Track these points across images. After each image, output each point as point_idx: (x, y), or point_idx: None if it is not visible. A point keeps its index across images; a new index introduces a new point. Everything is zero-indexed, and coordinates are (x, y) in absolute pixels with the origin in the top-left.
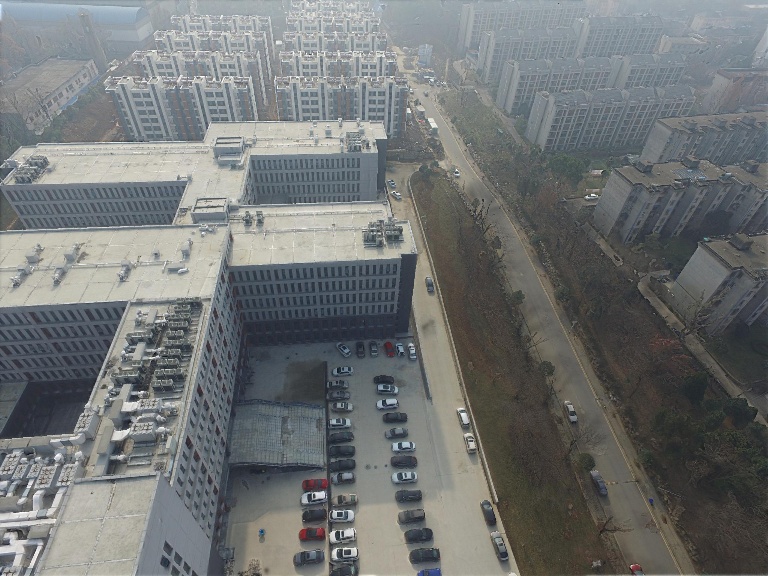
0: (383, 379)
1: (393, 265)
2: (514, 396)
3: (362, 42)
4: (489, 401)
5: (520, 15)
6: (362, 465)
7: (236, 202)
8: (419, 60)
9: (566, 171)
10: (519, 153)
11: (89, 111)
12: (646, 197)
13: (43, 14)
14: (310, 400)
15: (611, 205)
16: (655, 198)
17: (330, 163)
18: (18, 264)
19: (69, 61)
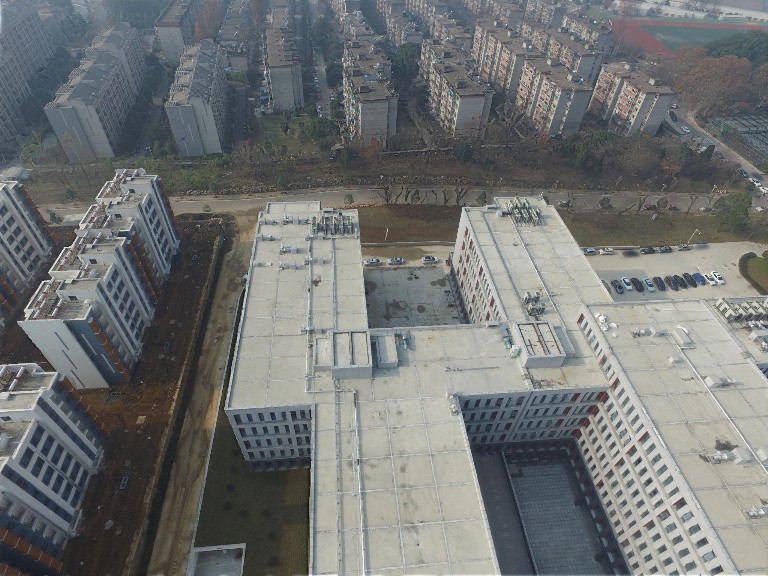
0: None
1: None
2: (572, 220)
3: None
4: (576, 234)
5: None
6: None
7: (508, 323)
8: None
9: None
10: None
11: None
12: None
13: None
14: None
15: (376, 127)
16: None
17: None
18: None
19: None
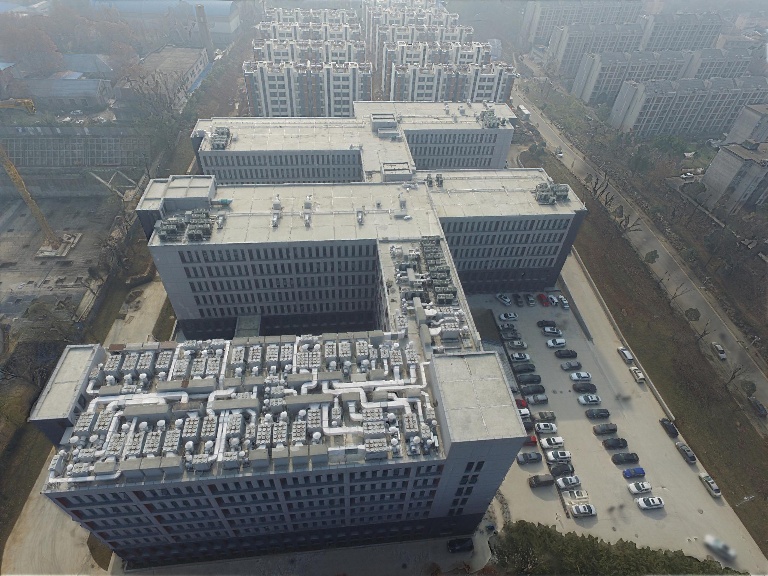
0: (547, 323)
1: (565, 220)
2: (670, 336)
3: (450, 34)
4: (647, 341)
5: (582, 12)
6: (549, 390)
7: (413, 167)
8: None
9: (668, 151)
10: (621, 135)
11: (211, 95)
12: (757, 171)
13: (143, 6)
14: None
15: (717, 180)
16: (765, 172)
17: (470, 138)
18: (266, 210)
19: (185, 49)
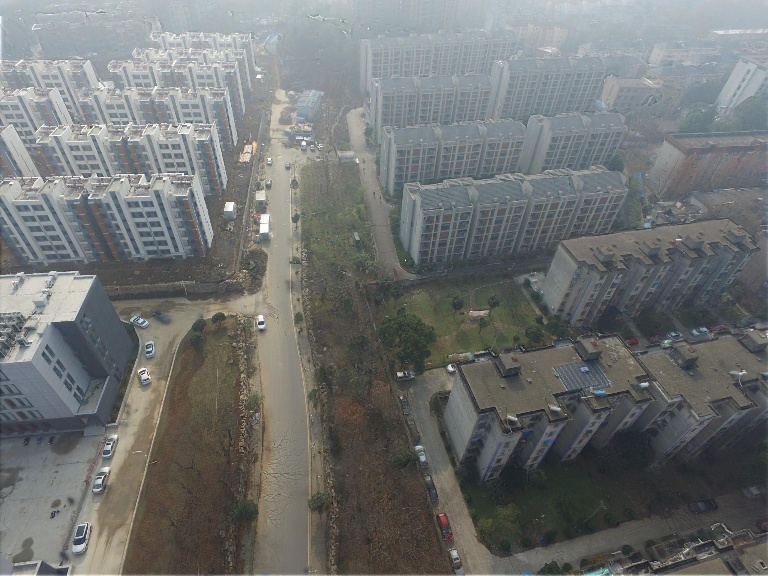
0: None
1: None
2: None
3: (188, 102)
4: None
5: (433, 52)
6: None
7: None
8: (298, 112)
9: None
10: (347, 300)
11: None
12: (500, 436)
13: None
14: None
15: (459, 420)
16: (517, 435)
17: None
18: None
19: None
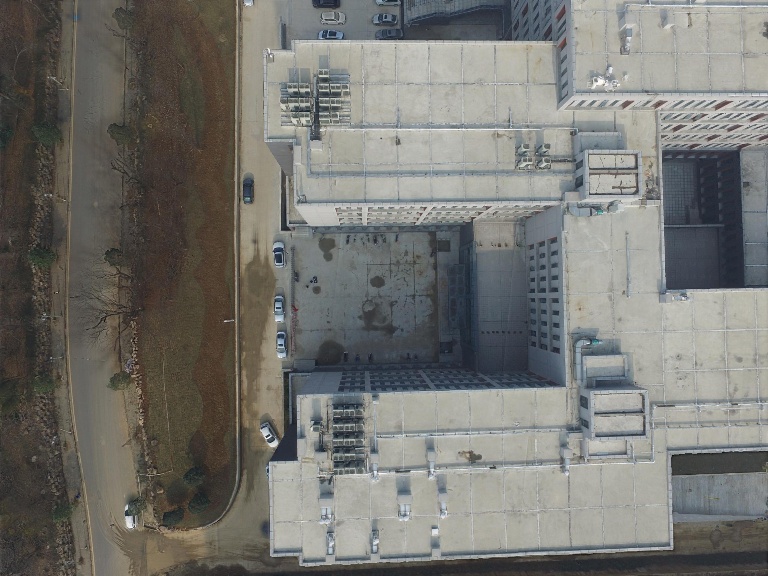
0: None
1: None
2: None
3: None
4: None
5: None
6: None
7: (570, 204)
8: None
9: None
10: None
11: None
12: None
13: None
14: (421, 36)
15: None
16: None
17: None
18: None
19: None
